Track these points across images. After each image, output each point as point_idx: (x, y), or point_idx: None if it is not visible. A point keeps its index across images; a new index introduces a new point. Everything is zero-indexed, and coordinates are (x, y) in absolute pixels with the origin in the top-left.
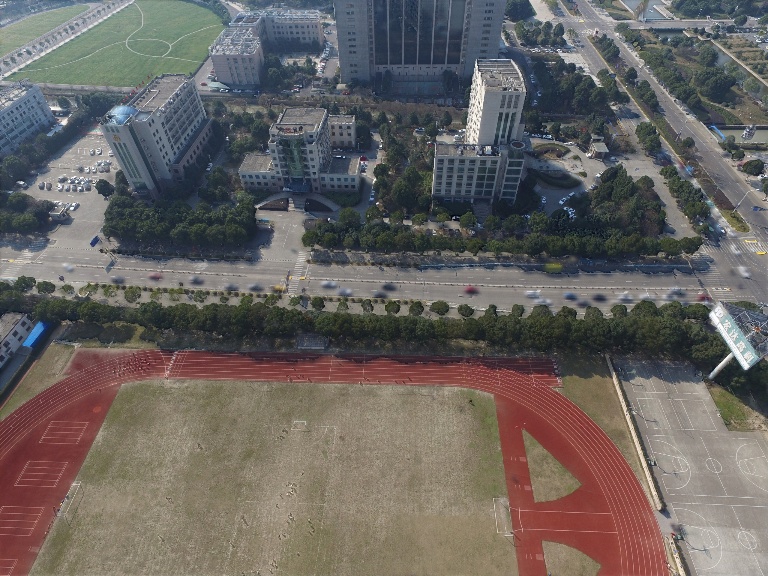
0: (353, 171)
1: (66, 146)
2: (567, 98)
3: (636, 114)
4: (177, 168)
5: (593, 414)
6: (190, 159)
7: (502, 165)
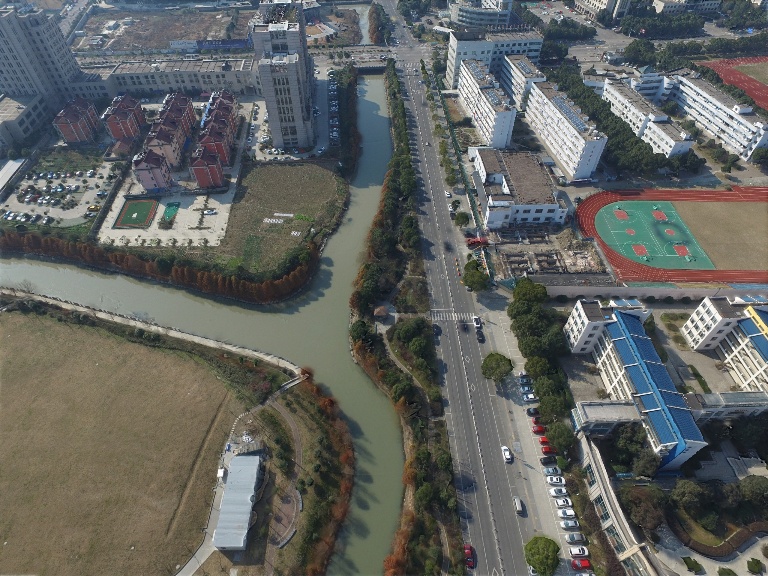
0: None
1: None
2: None
3: None
4: (629, 6)
5: None
6: None
7: None
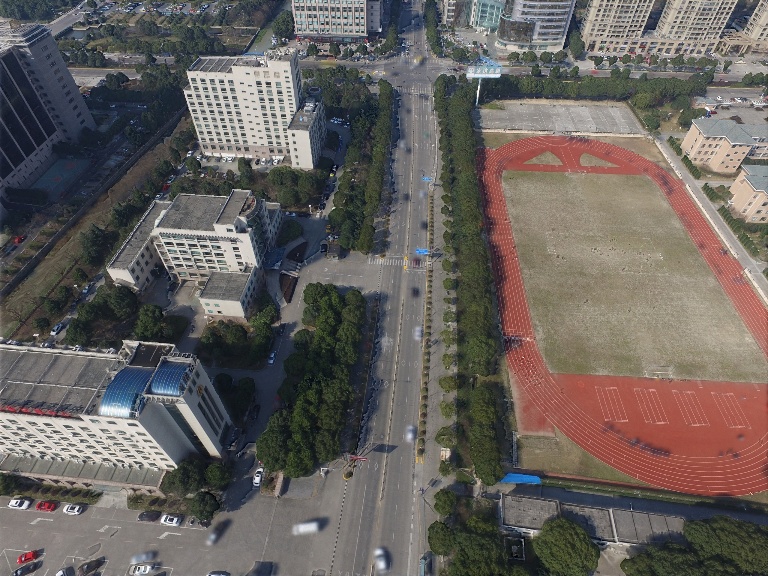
0: (272, 206)
1: None
2: (177, 90)
3: None
4: None
5: (507, 141)
6: None
7: None
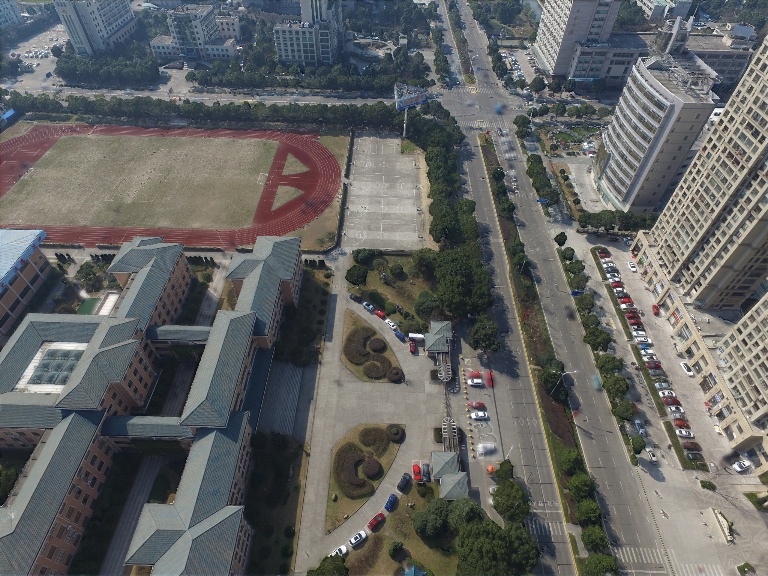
0: (227, 44)
1: (32, 36)
2: (397, 16)
3: (445, 29)
4: (108, 42)
5: (331, 148)
6: (119, 39)
7: (317, 36)
